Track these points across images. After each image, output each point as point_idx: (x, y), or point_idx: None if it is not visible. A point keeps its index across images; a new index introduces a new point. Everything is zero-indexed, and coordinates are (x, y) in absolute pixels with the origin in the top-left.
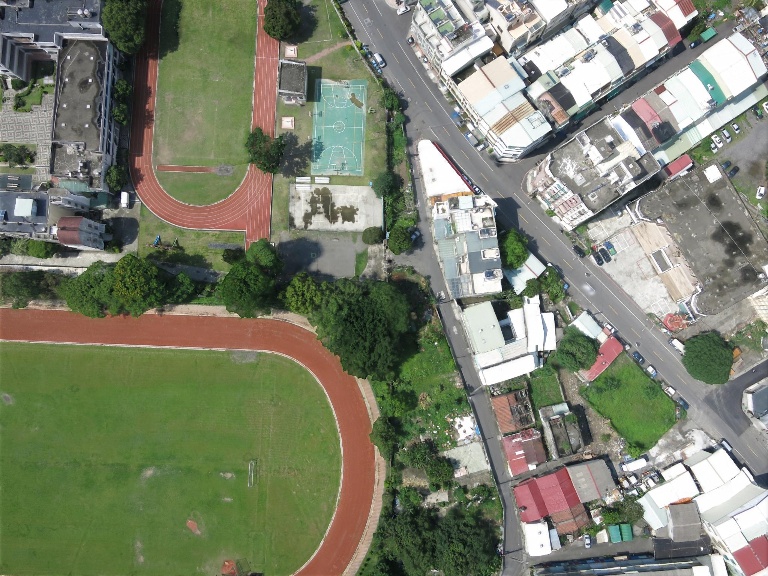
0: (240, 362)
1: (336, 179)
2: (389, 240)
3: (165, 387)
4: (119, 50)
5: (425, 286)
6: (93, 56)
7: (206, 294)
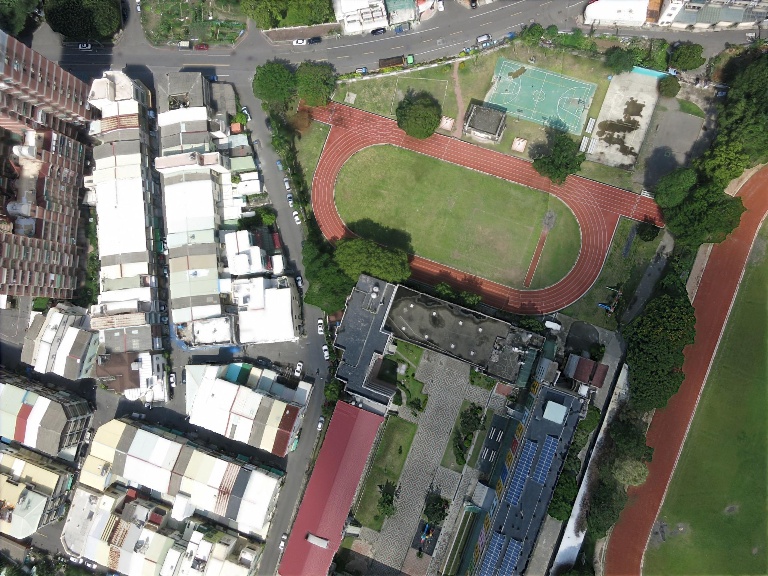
0: (763, 257)
1: (593, 112)
2: (687, 65)
3: (767, 342)
4: (403, 283)
5: (737, 50)
6: (410, 304)
7: (681, 270)
